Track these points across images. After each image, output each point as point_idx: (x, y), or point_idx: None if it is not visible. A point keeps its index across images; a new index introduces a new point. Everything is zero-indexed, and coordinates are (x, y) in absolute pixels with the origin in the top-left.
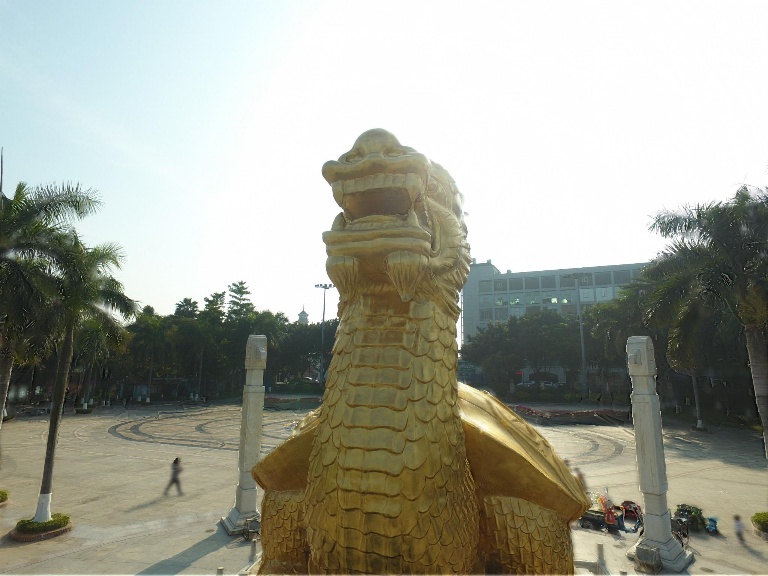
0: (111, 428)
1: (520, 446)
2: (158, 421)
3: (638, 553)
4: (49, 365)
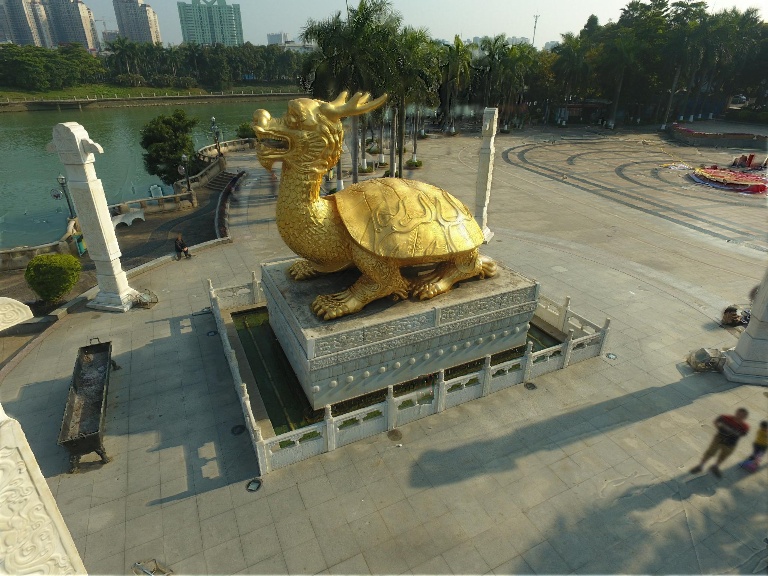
0: (509, 149)
1: (365, 225)
2: (550, 146)
3: (699, 352)
4: (479, 93)
